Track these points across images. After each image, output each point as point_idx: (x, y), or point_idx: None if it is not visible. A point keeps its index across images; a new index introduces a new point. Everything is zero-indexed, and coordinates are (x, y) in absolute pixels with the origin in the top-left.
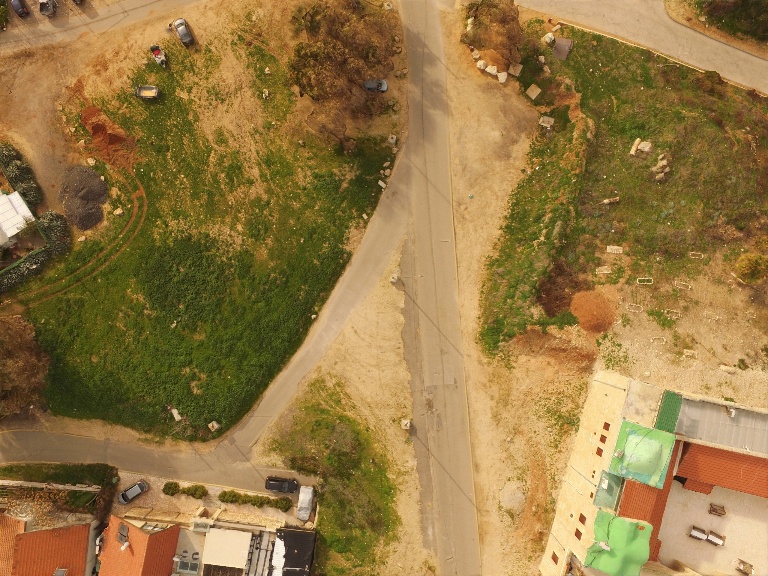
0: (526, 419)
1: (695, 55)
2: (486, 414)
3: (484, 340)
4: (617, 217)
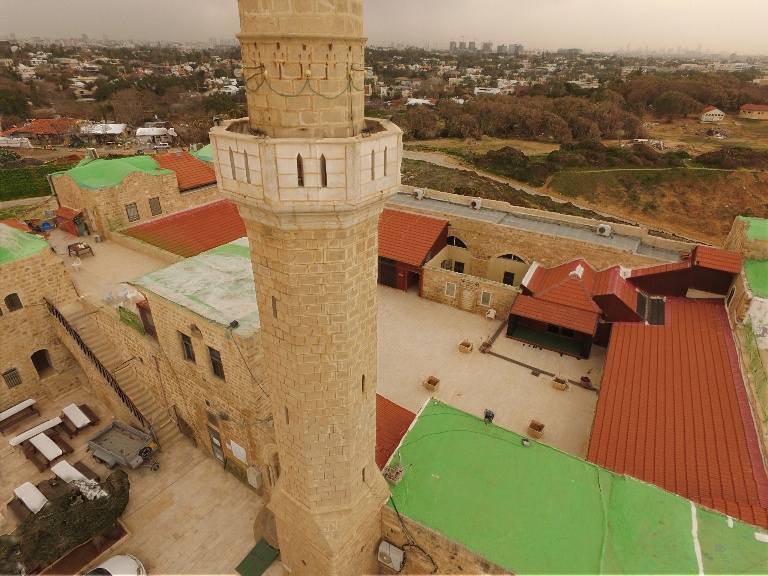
0: None
1: None
2: None
3: None
4: None
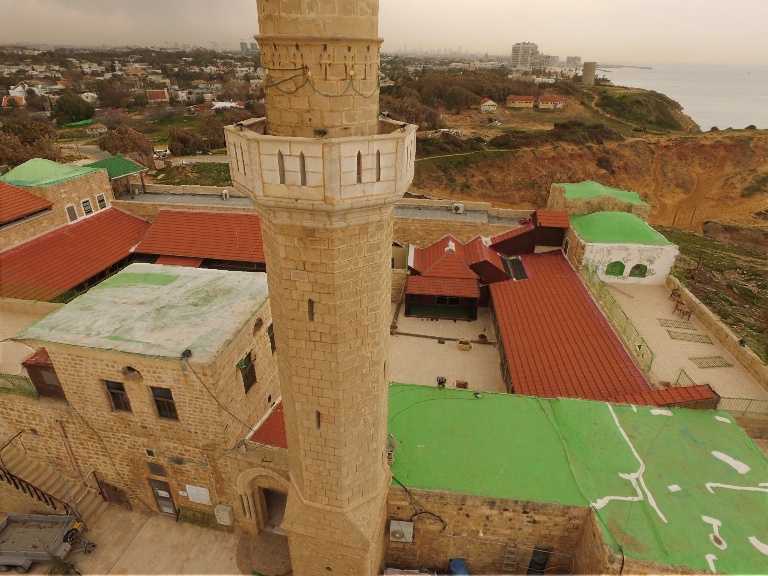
0: None
1: None
2: None
3: None
4: None
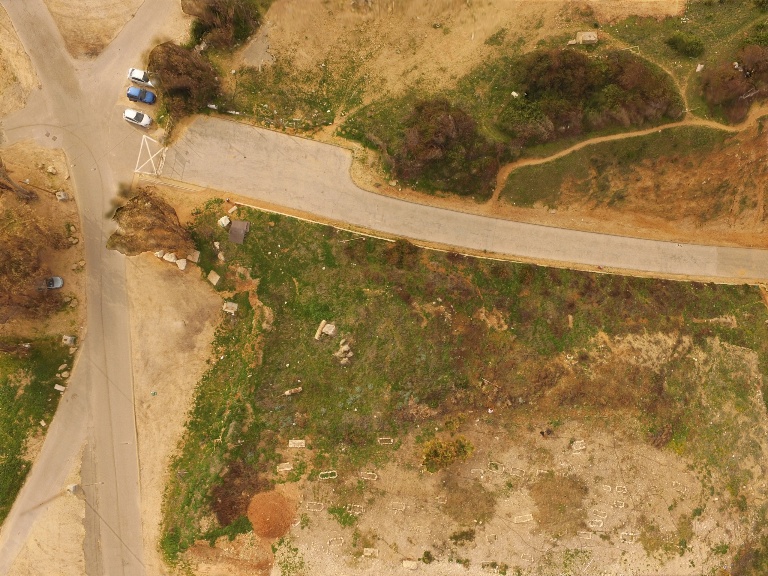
0: None
1: (388, 221)
2: None
3: (164, 549)
4: (299, 408)
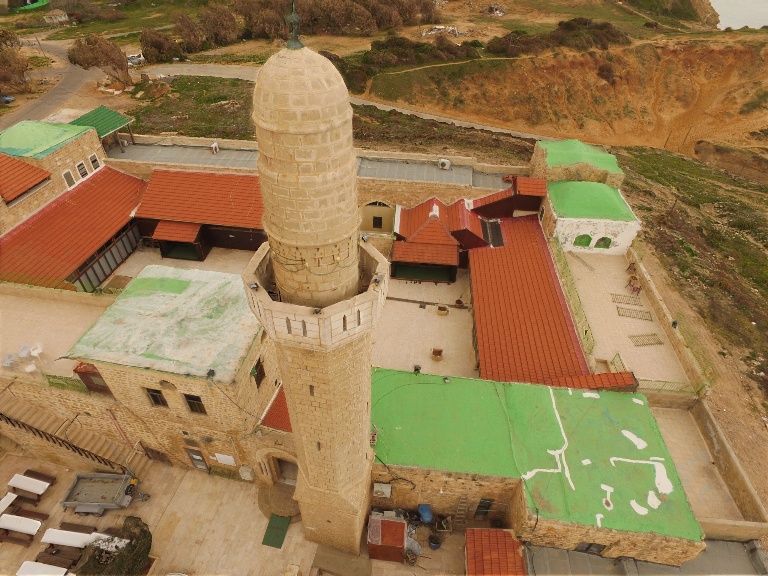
0: None
1: None
2: None
3: None
4: None
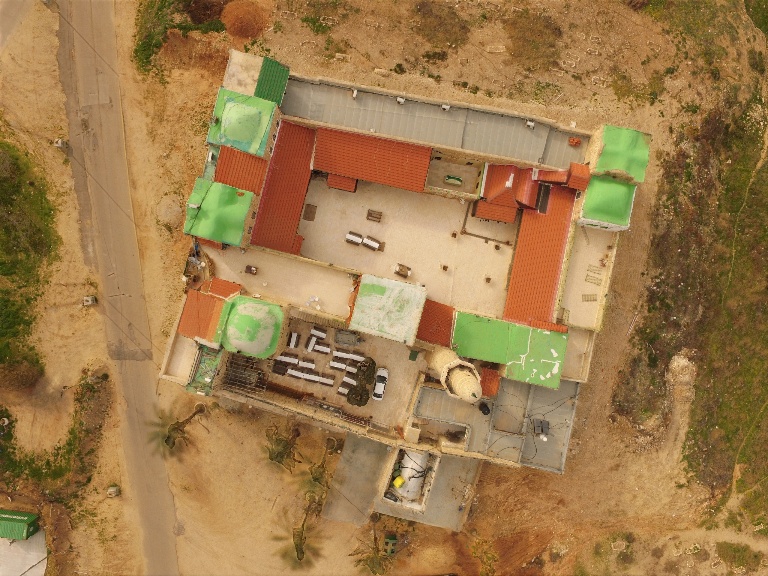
0: (182, 134)
1: None
2: (142, 131)
3: (138, 57)
4: None
